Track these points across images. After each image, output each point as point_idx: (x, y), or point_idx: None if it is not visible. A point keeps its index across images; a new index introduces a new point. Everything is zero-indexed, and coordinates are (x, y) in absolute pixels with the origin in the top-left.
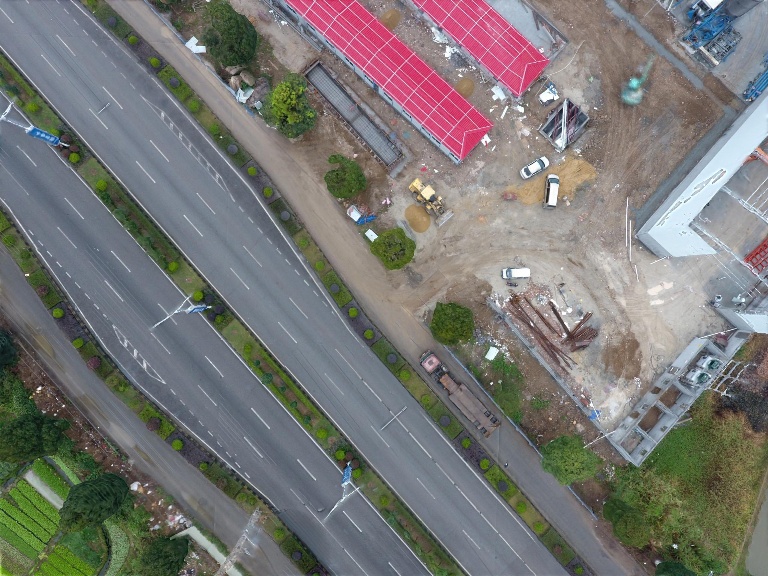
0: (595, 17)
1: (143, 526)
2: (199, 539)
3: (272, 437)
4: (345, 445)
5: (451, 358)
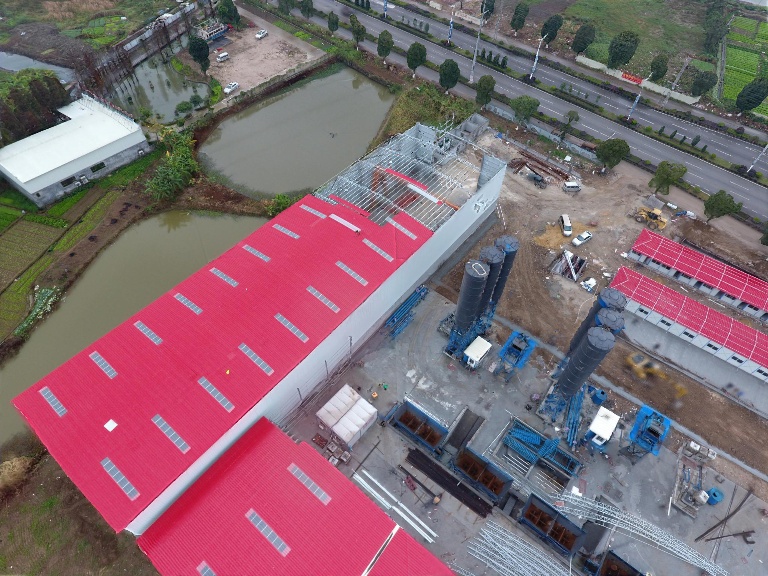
0: None
1: (715, 103)
2: (686, 97)
3: (673, 130)
4: (633, 126)
5: (590, 158)
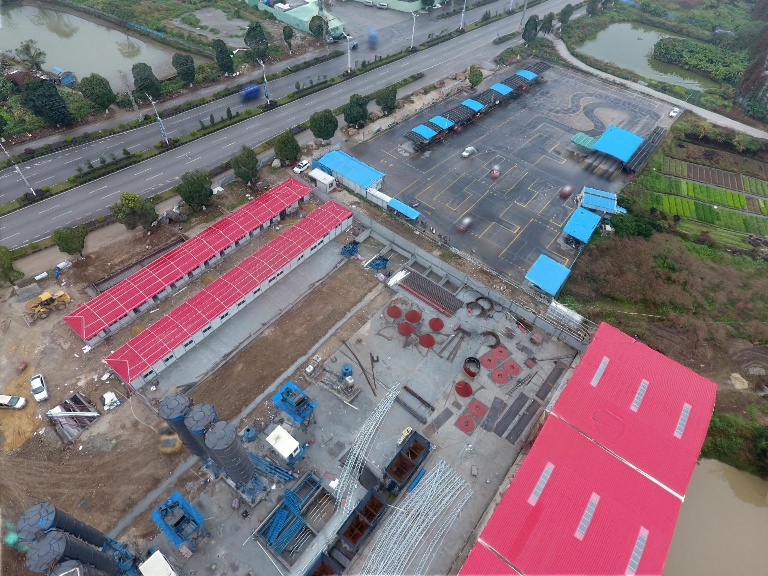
0: (179, 441)
1: None
2: None
3: None
4: None
5: None
